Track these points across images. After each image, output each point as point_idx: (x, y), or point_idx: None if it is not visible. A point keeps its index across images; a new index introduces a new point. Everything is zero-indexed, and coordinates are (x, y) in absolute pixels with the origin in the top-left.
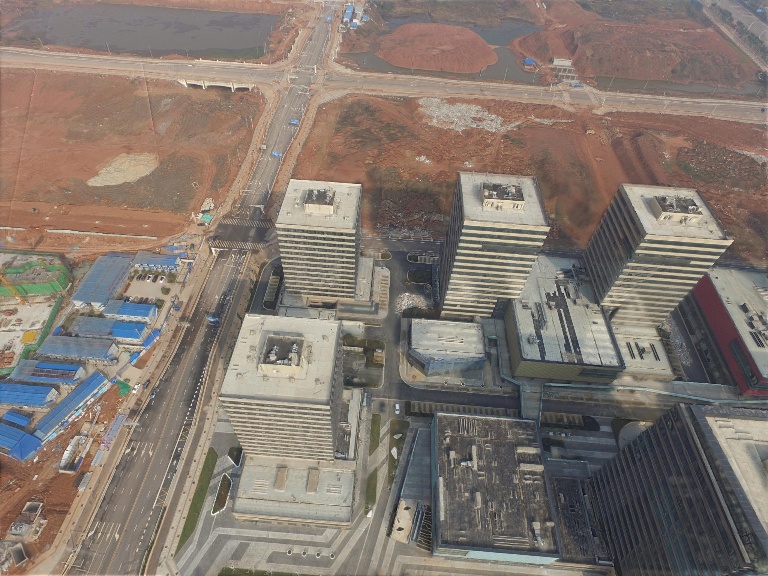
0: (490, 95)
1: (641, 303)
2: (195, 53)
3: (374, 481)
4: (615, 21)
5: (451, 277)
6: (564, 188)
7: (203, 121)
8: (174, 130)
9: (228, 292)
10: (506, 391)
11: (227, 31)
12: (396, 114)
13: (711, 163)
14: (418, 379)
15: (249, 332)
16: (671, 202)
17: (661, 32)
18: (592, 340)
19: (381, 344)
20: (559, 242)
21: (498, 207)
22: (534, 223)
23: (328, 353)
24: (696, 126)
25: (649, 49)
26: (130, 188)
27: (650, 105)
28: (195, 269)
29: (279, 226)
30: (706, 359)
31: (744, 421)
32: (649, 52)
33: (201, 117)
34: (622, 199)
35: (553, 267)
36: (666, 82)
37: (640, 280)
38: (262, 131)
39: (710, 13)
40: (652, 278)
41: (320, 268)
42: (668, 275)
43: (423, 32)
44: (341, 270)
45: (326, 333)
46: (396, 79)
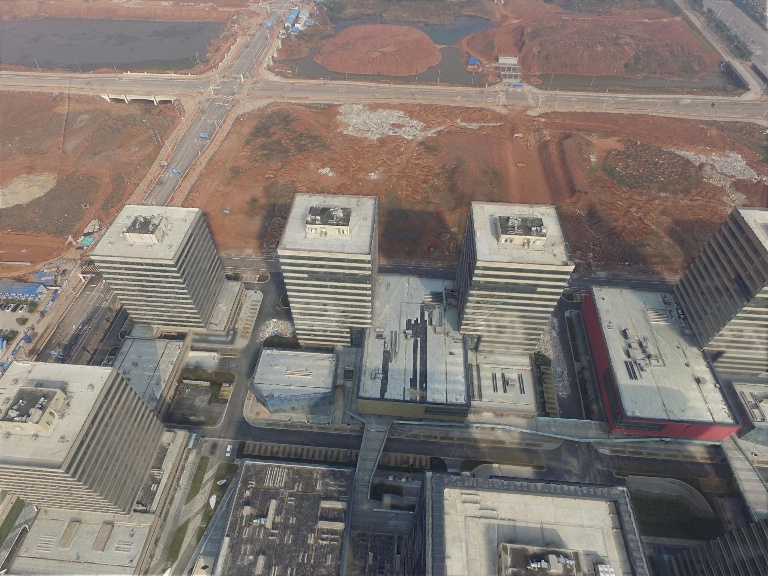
0: (420, 99)
1: (502, 331)
2: (129, 66)
3: (182, 534)
4: (577, 13)
5: (291, 307)
6: (469, 199)
7: (113, 137)
8: (81, 148)
9: (87, 321)
10: (353, 429)
11: (168, 41)
12: (313, 123)
13: (640, 166)
14: (261, 416)
15: (11, 381)
16: (513, 223)
17: (619, 24)
18: (443, 374)
19: (231, 377)
20: (454, 258)
21: (322, 233)
22: (356, 250)
23: (87, 405)
24: (635, 125)
25: (601, 43)
26: (19, 211)
27: (591, 103)
28: (60, 297)
29: (94, 258)
30: (586, 390)
31: (496, 494)
32: (600, 46)
33: (112, 133)
34: (470, 219)
35: (423, 290)
36: (618, 77)
37: (491, 308)
38: (168, 146)
39: (681, 0)
40: (503, 306)
41: (156, 299)
42: (519, 303)
43: (367, 34)
44: (178, 300)
45: (94, 381)
46: (325, 85)
